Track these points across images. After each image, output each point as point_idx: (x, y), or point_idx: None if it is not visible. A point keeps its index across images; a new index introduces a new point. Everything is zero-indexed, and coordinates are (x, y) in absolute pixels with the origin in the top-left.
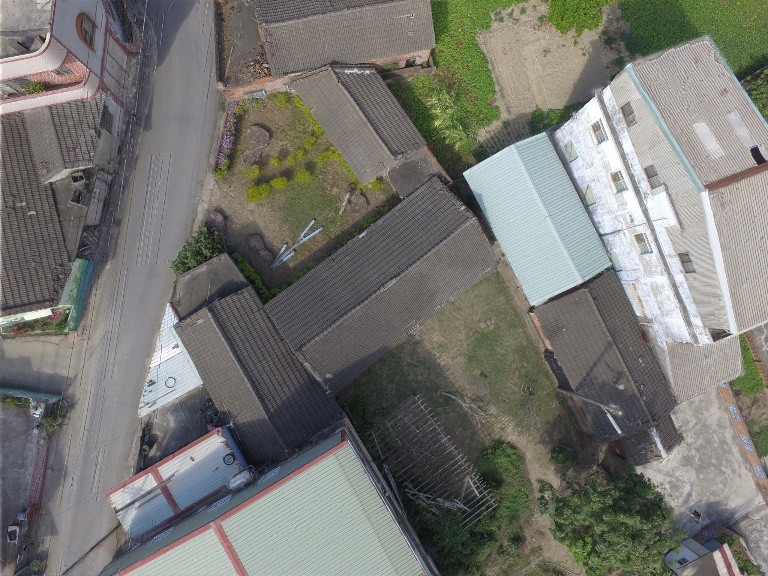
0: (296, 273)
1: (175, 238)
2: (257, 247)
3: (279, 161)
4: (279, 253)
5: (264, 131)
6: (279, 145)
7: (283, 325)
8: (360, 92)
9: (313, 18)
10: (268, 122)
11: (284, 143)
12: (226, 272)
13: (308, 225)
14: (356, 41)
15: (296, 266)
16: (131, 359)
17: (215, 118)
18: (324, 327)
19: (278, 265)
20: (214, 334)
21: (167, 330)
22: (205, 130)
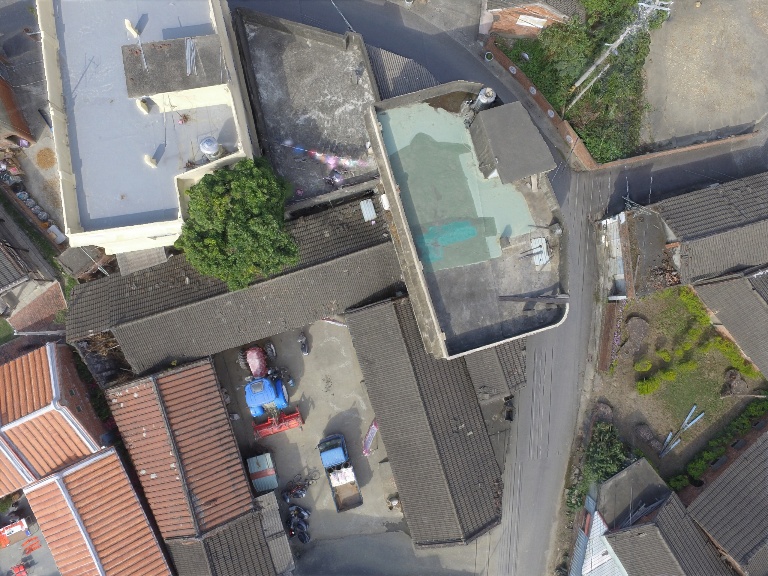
0: (684, 460)
1: (563, 430)
2: (647, 437)
3: (669, 355)
4: (666, 441)
5: (644, 322)
6: (656, 333)
7: (715, 532)
8: (767, 294)
9: (731, 231)
10: (643, 311)
11: (661, 331)
12: (646, 476)
13: (690, 411)
14: (763, 246)
15: (682, 452)
16: (532, 552)
17: (590, 309)
18: (763, 536)
19: (666, 453)
20: (659, 548)
21: (597, 538)
22: (583, 322)
